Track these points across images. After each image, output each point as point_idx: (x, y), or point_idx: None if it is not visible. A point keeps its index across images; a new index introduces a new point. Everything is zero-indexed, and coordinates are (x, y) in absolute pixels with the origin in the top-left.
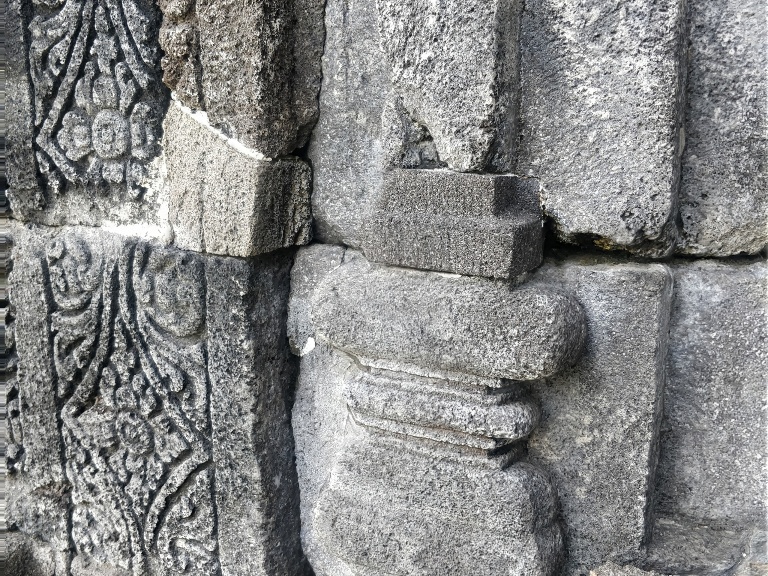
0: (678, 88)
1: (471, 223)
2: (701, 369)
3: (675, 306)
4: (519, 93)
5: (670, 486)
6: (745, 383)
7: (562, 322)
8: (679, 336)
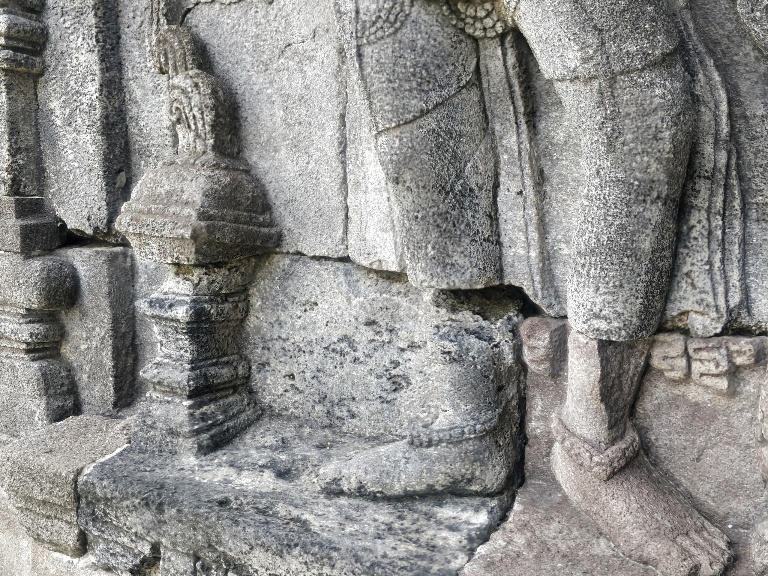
0: (108, 151)
1: (4, 223)
2: None
3: (135, 271)
4: (40, 153)
5: None
6: None
7: (44, 275)
8: (139, 289)
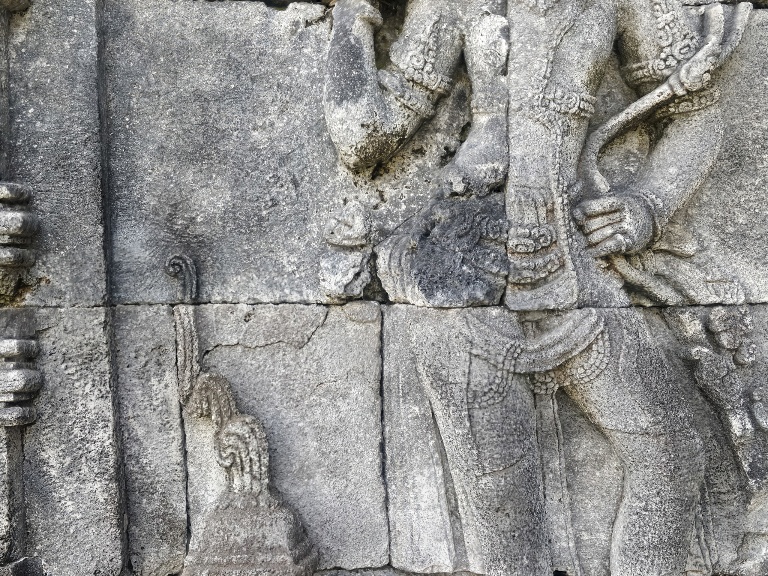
0: (119, 497)
1: None
2: None
3: None
4: (25, 508)
5: None
6: None
7: None
8: None
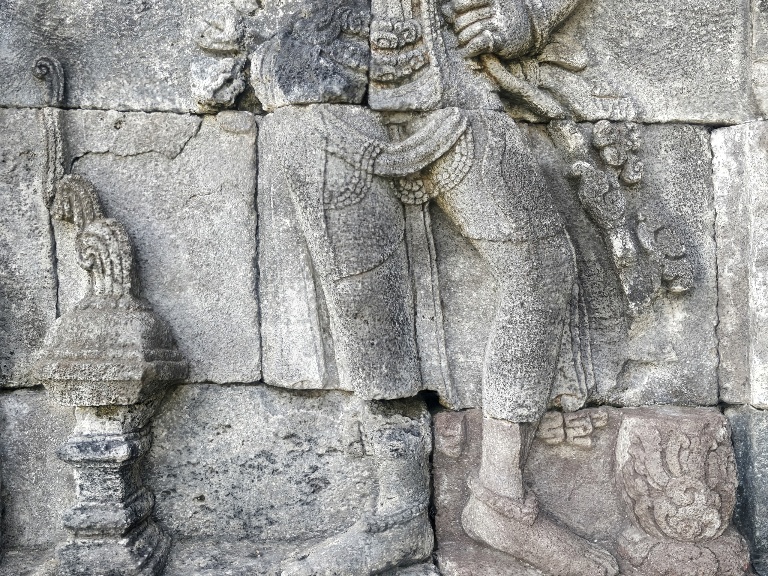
0: None
1: None
2: (22, 454)
3: (2, 419)
4: None
5: (13, 530)
6: (48, 458)
7: None
8: (7, 436)
